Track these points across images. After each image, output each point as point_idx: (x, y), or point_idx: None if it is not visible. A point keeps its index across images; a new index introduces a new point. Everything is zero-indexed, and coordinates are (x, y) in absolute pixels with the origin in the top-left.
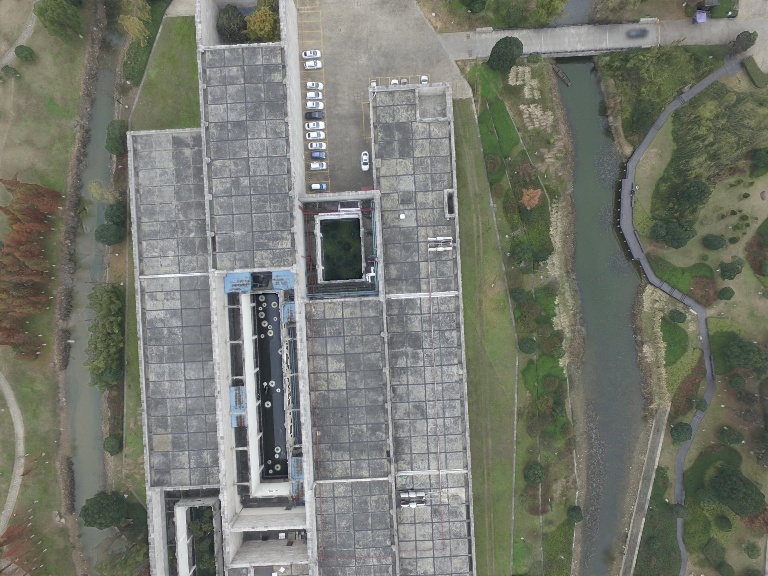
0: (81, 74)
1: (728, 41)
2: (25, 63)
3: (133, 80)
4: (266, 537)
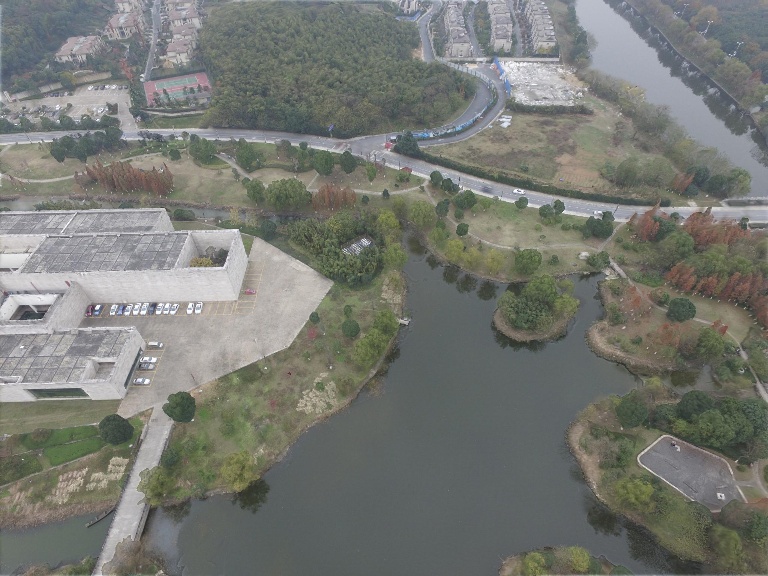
0: (236, 205)
1: None
2: None
3: (220, 223)
4: None
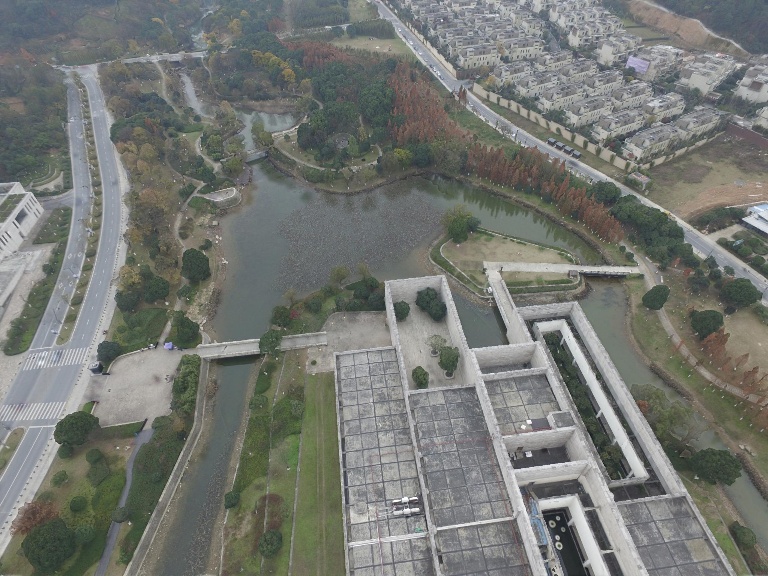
0: None
1: None
2: None
3: None
4: (544, 452)
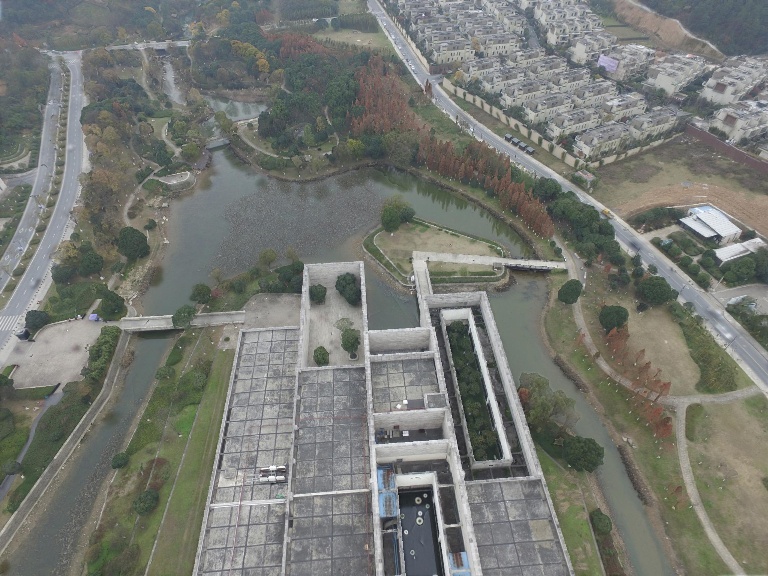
0: None
1: None
2: None
3: None
4: (421, 432)
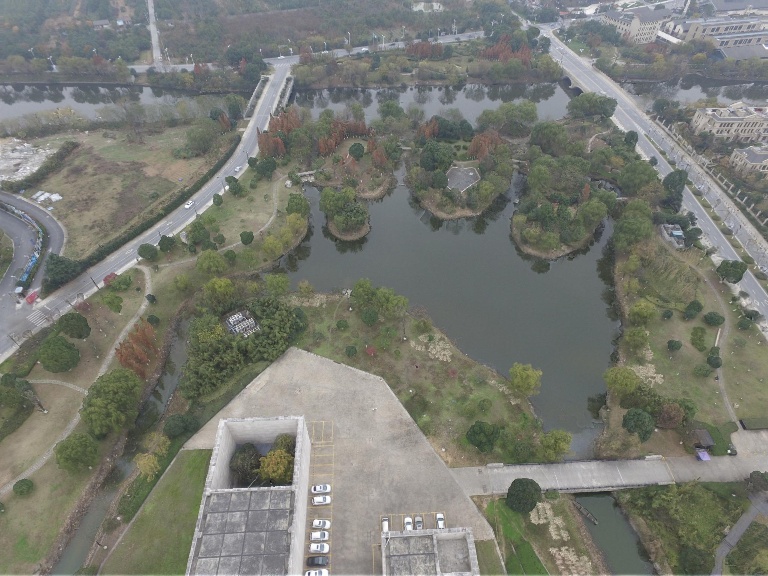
0: (72, 507)
1: (742, 478)
2: (18, 496)
3: (125, 516)
4: None
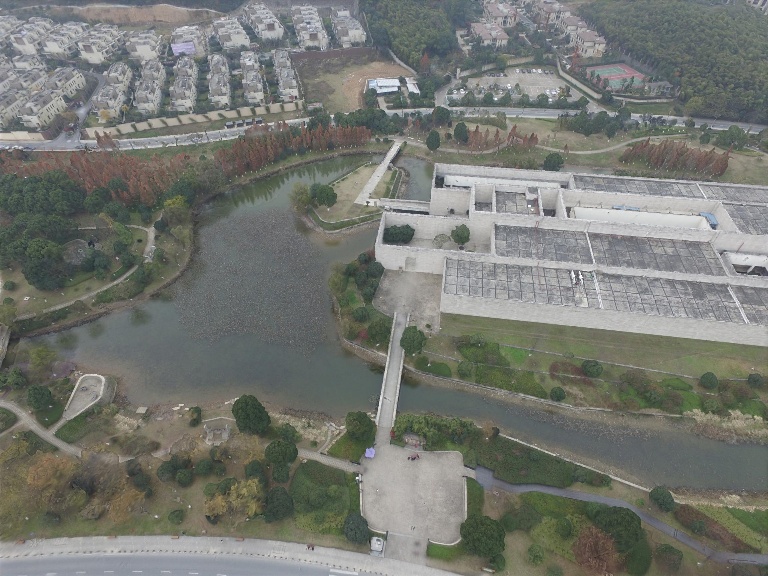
0: None
1: None
2: None
3: None
4: None
